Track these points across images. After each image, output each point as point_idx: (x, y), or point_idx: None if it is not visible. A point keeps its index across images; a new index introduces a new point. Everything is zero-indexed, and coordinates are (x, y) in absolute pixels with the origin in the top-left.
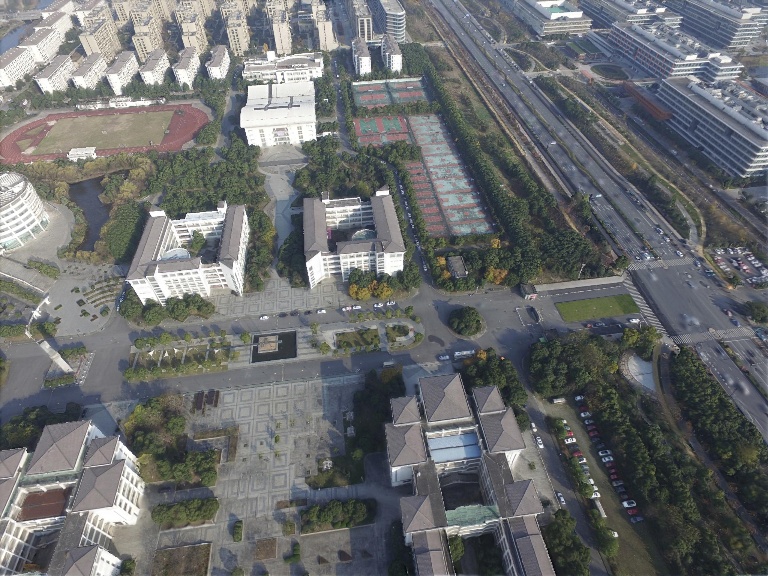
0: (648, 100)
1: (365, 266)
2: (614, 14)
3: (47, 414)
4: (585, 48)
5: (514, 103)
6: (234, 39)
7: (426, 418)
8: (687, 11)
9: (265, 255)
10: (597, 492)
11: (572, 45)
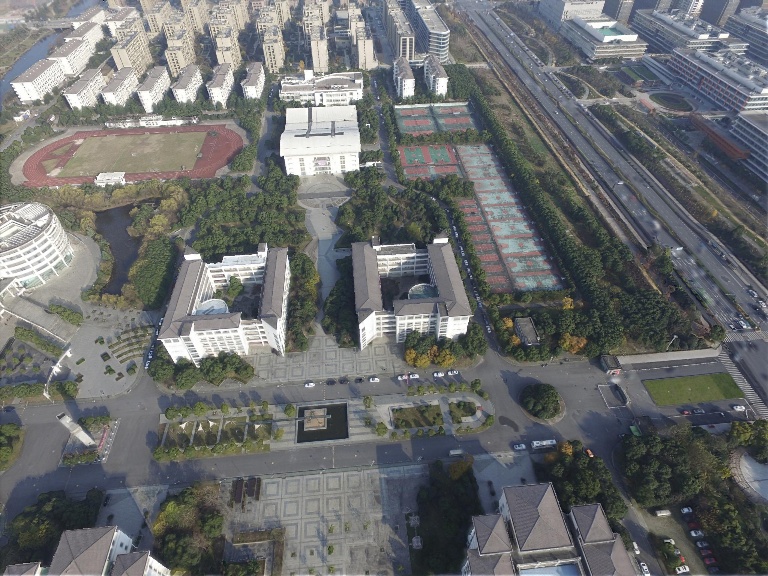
0: (721, 136)
1: (423, 327)
2: (671, 38)
3: (65, 505)
4: (642, 74)
5: (570, 134)
6: (270, 55)
7: (517, 545)
8: (750, 37)
9: (309, 308)
10: None
11: (627, 70)
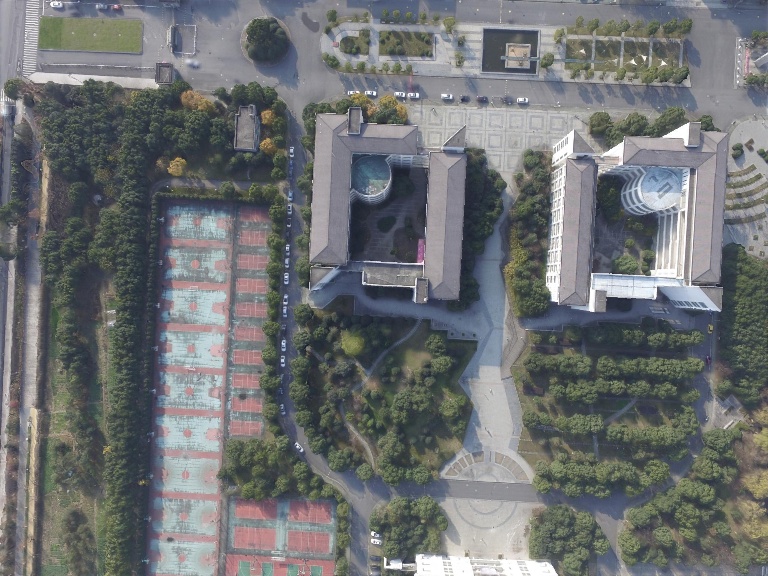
0: None
1: None
2: None
3: None
4: None
5: None
6: None
7: None
8: None
9: None
10: None
11: None
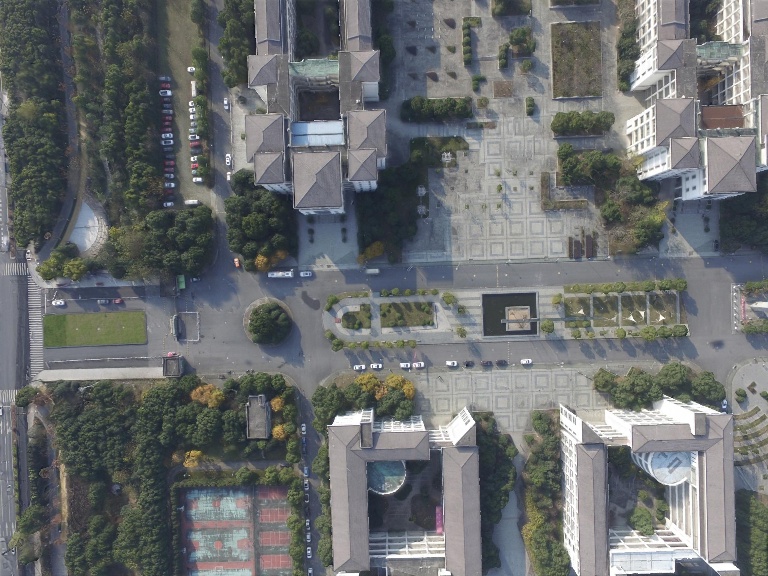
0: None
1: None
2: None
3: (759, 234)
4: None
5: None
6: None
7: None
8: None
9: (536, 474)
10: (191, 106)
11: None
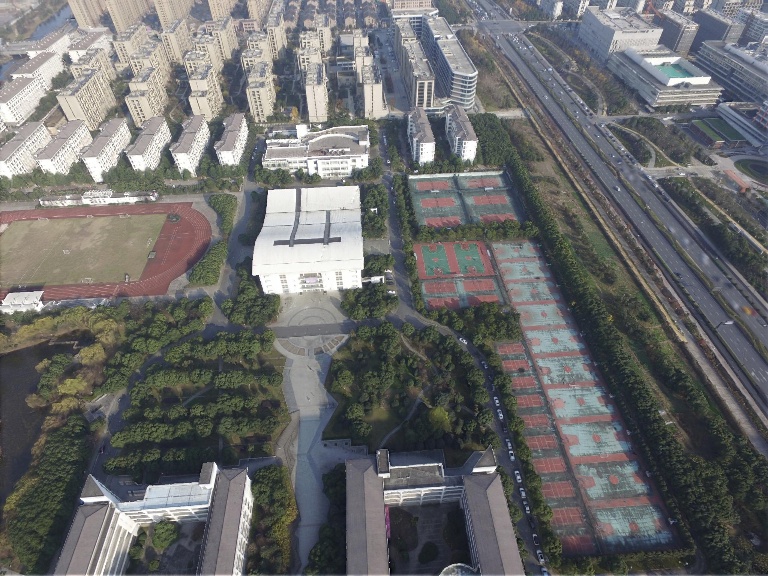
0: None
1: None
2: (753, 82)
3: None
4: (721, 132)
5: (641, 225)
6: (255, 102)
7: None
8: None
9: None
10: None
11: (701, 125)
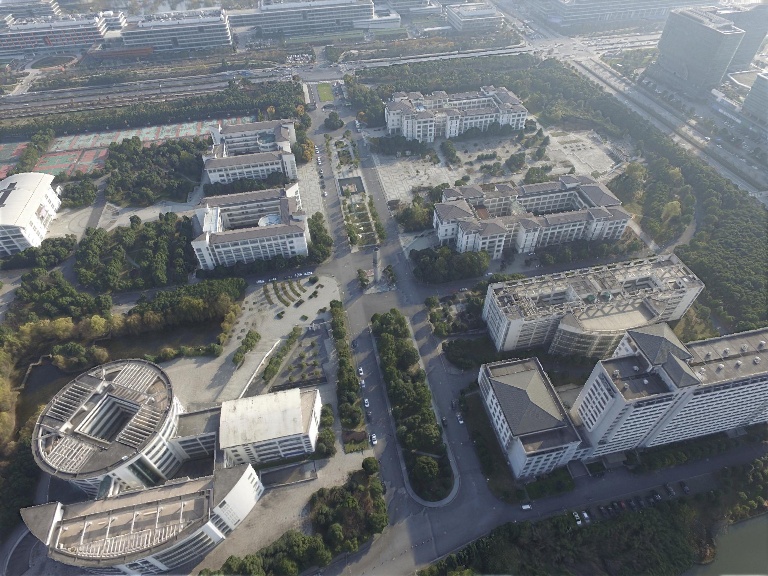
0: (127, 50)
1: None
2: None
3: None
4: None
5: None
6: None
7: None
8: None
9: None
10: None
11: None
